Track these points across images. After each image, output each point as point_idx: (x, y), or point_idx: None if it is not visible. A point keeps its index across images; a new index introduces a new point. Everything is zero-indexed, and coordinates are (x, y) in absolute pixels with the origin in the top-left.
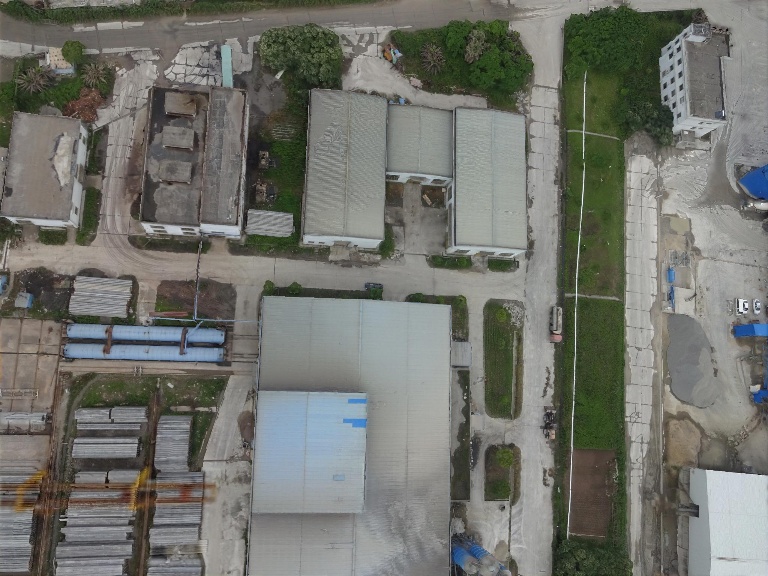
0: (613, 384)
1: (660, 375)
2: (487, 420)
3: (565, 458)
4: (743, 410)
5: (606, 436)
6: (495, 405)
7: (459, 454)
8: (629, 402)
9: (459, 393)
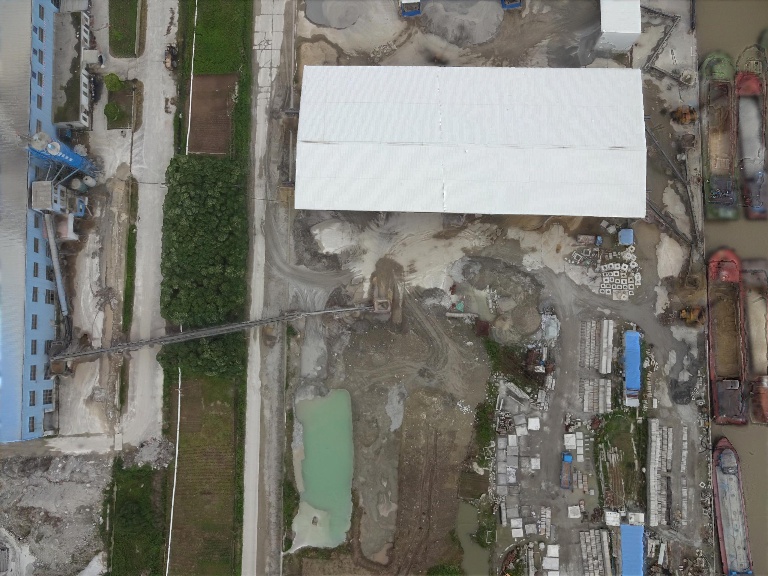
0: (234, 12)
1: (294, 3)
2: (111, 60)
3: (186, 86)
4: (390, 26)
5: (226, 61)
6: (119, 47)
7: (71, 84)
8: (258, 31)
9: (72, 32)
